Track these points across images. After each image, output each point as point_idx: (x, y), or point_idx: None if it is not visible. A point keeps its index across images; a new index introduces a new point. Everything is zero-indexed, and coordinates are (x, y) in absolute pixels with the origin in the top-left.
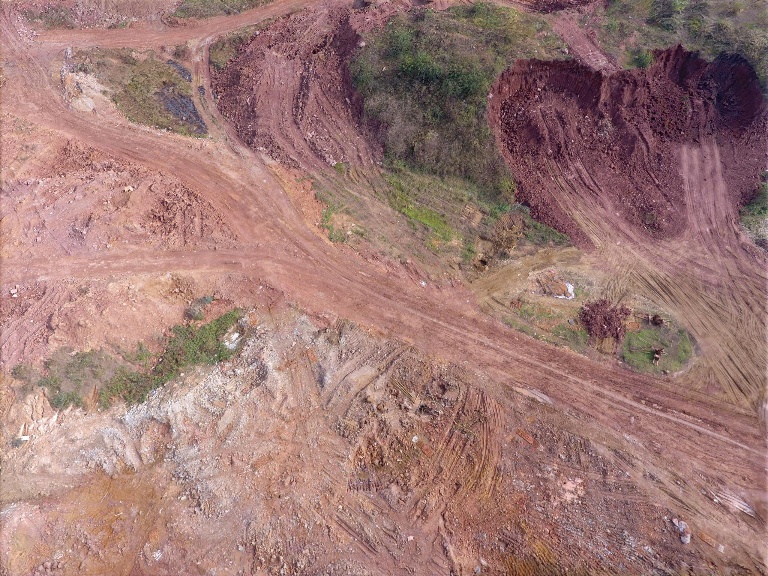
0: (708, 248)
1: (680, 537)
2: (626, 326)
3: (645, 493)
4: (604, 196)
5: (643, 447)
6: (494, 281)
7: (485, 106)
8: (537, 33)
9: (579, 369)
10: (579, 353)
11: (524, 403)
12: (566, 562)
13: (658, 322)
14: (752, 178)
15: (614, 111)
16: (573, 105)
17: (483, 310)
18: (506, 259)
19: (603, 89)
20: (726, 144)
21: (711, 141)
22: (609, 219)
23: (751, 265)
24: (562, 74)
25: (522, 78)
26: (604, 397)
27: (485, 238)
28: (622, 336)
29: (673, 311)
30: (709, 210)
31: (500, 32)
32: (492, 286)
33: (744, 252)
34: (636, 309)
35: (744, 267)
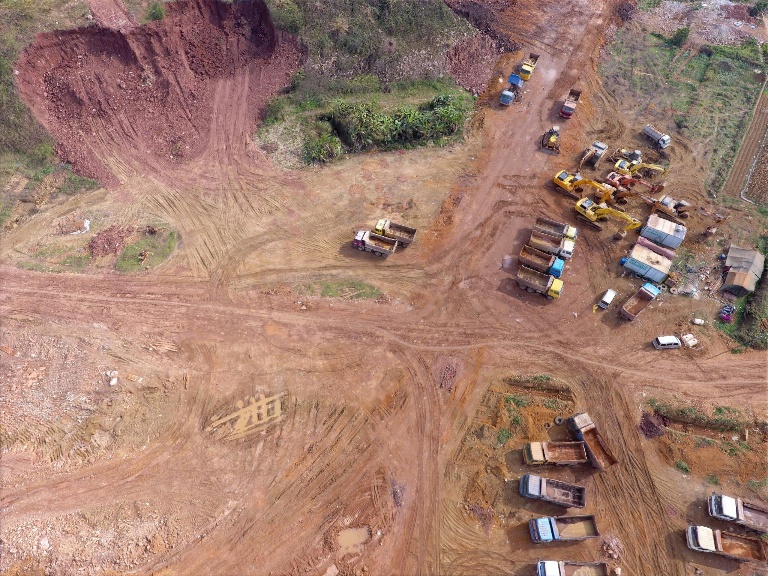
0: (219, 161)
1: (109, 382)
2: (127, 241)
3: (94, 361)
4: (139, 139)
5: (106, 329)
6: (19, 235)
7: (12, 83)
8: (63, 5)
9: (71, 286)
10: (78, 273)
11: (16, 325)
12: (12, 429)
13: (154, 231)
14: (269, 95)
15: (154, 62)
16: (114, 64)
17: (2, 262)
18: (35, 214)
19: (133, 45)
20: (256, 71)
21: (244, 71)
22: (139, 157)
23: (249, 167)
24: (96, 39)
25: (58, 49)
26: (85, 301)
27: (25, 200)
28: (120, 250)
29: (171, 219)
30: (229, 130)
31: (21, 11)
32: (16, 240)
33: (247, 158)
34: (140, 226)
35: (243, 170)
